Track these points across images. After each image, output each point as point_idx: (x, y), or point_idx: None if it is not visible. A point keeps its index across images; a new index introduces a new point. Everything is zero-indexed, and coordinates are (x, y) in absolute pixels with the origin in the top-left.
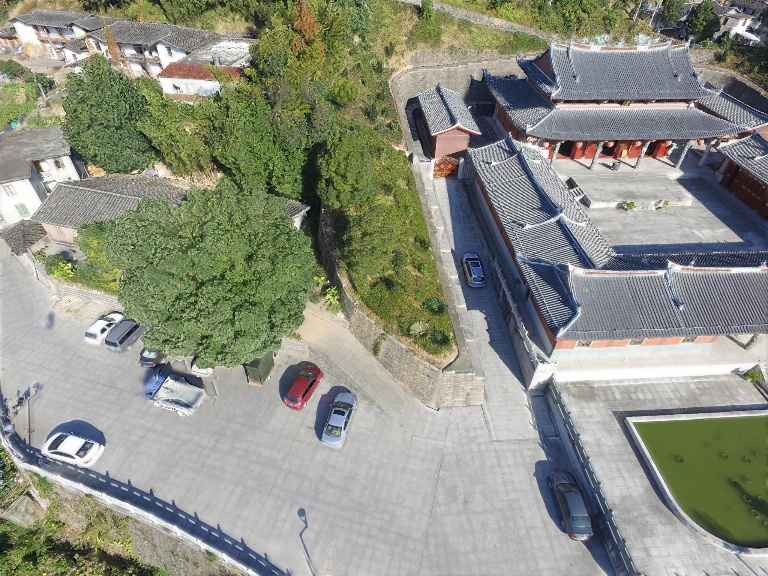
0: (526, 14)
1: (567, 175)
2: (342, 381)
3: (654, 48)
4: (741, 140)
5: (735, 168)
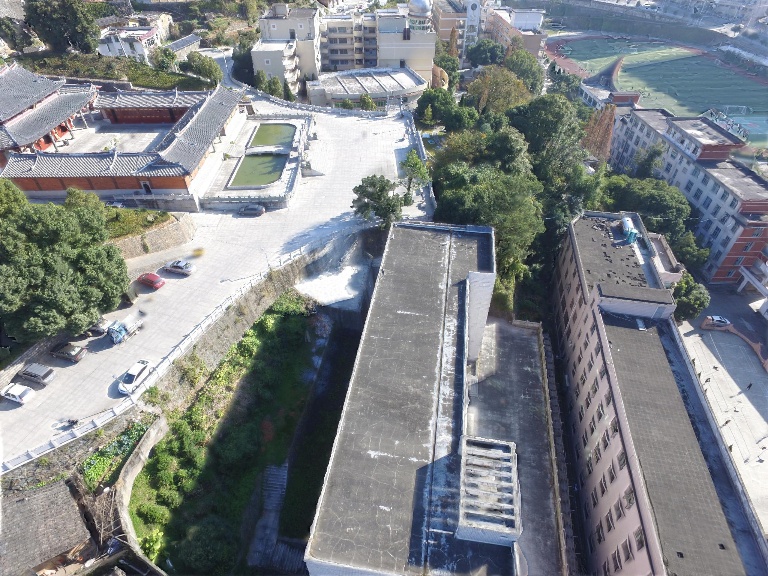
0: None
1: None
2: (155, 269)
3: (3, 72)
4: (97, 98)
5: (111, 112)
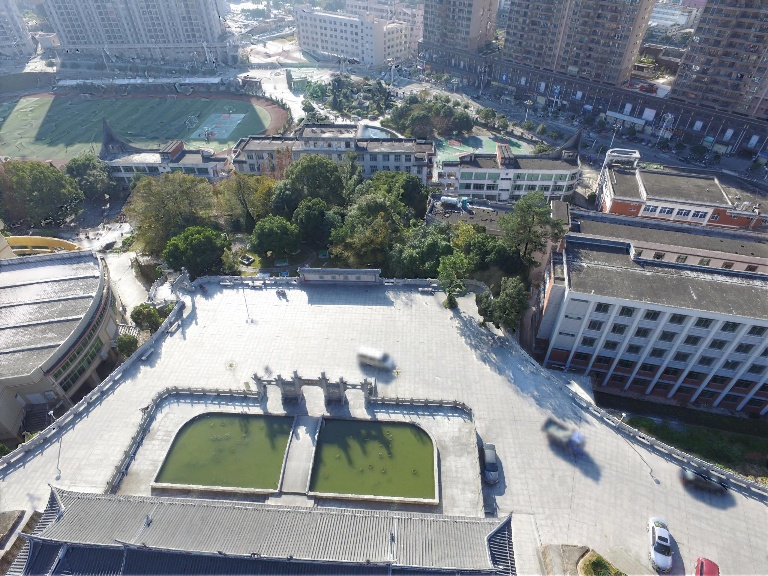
0: None
1: None
2: None
3: None
4: None
5: None
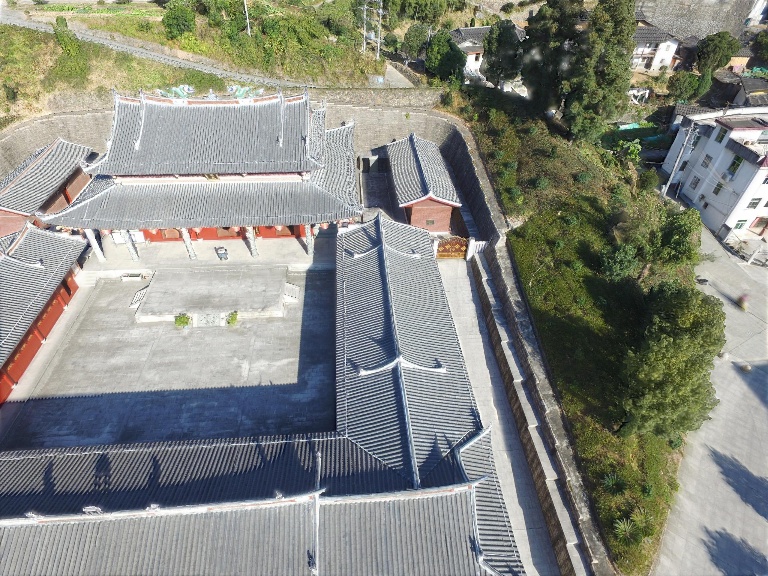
0: (214, 46)
1: (149, 268)
2: None
3: (262, 101)
4: (364, 225)
5: None
